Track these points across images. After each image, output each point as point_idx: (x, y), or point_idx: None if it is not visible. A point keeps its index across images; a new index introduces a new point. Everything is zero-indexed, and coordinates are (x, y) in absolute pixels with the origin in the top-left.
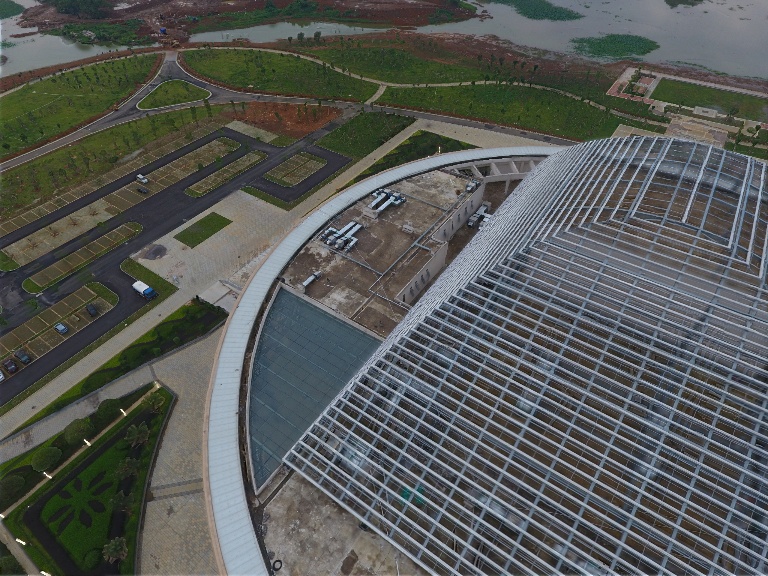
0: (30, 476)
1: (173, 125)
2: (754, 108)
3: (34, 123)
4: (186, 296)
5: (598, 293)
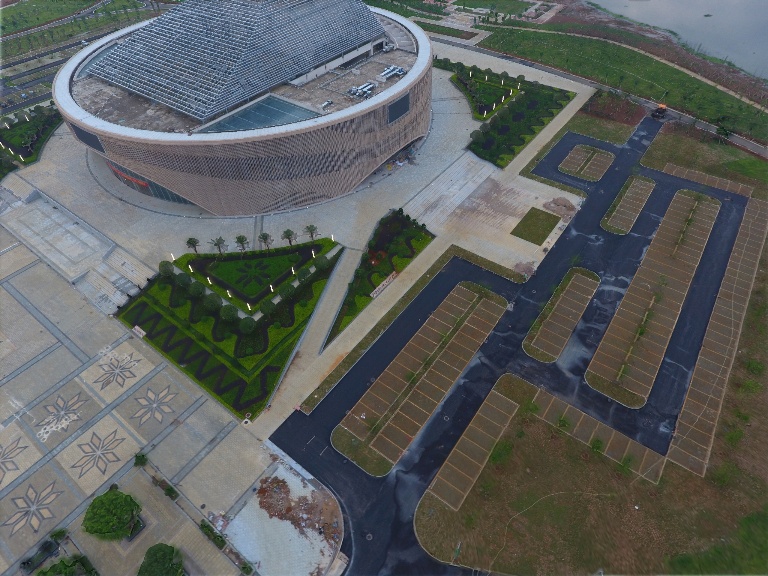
0: (0, 130)
1: (110, 16)
2: (518, 8)
3: (23, 19)
4: None
5: (209, 5)
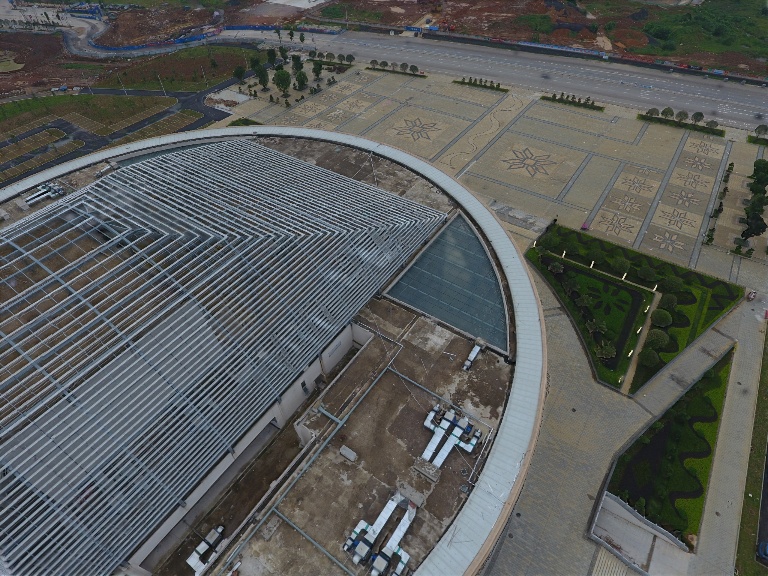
0: None
1: None
2: None
3: None
4: (710, 557)
5: (208, 209)
